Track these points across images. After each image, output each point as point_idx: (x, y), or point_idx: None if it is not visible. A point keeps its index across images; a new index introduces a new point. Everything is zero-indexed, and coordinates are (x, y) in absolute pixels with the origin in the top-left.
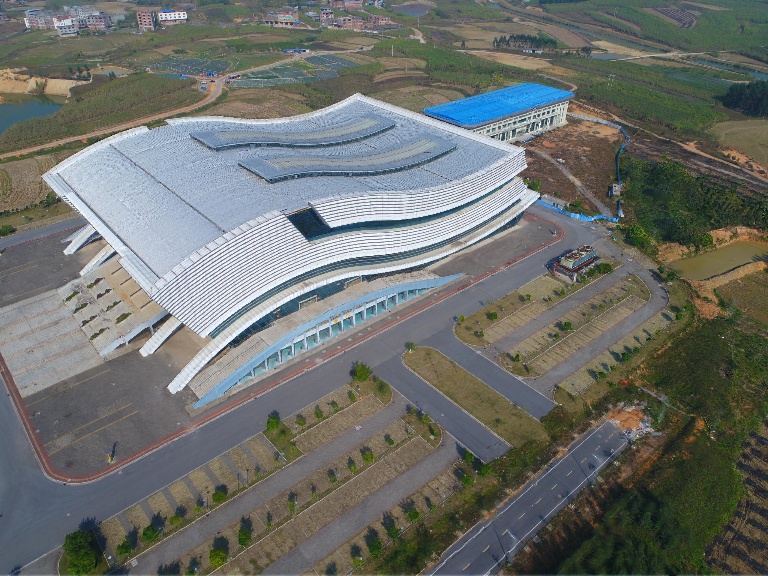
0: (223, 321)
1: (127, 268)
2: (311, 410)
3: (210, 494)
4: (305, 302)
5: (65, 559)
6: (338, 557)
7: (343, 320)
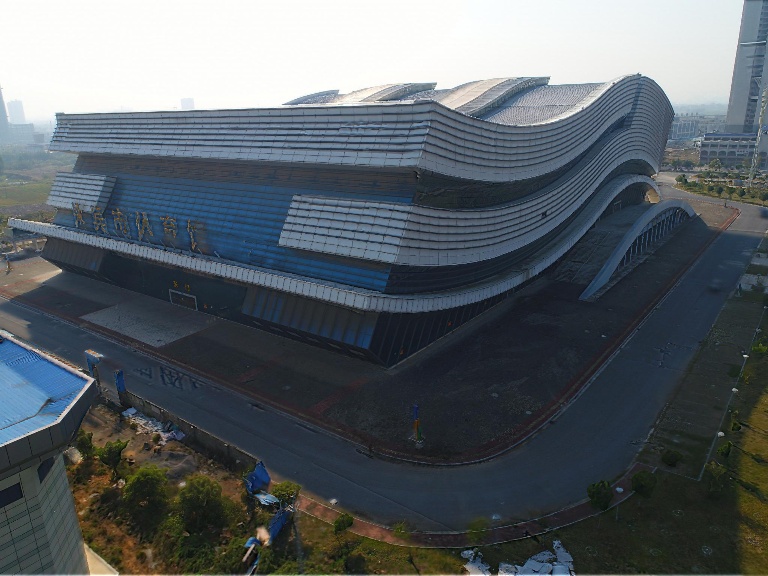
0: None
1: None
2: None
3: None
4: None
5: None
6: None
7: None
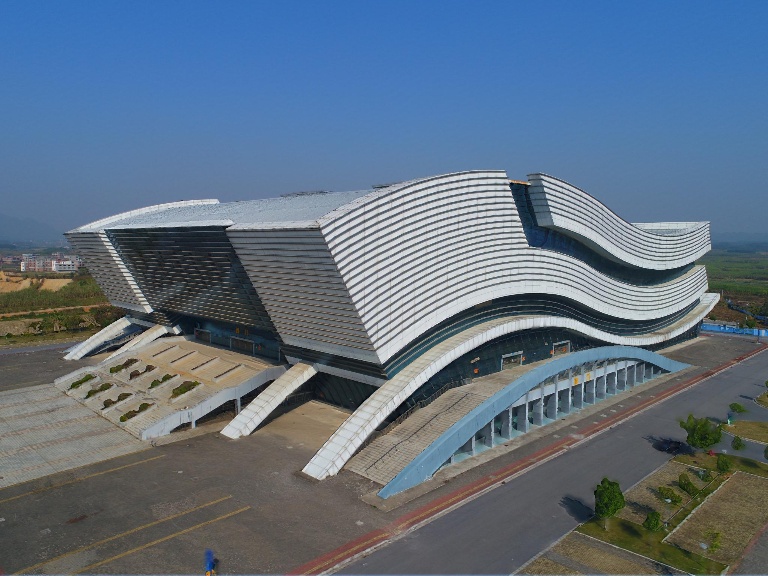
0: (407, 345)
1: (249, 226)
2: (645, 494)
3: None
4: (507, 360)
5: None
6: None
7: (583, 383)
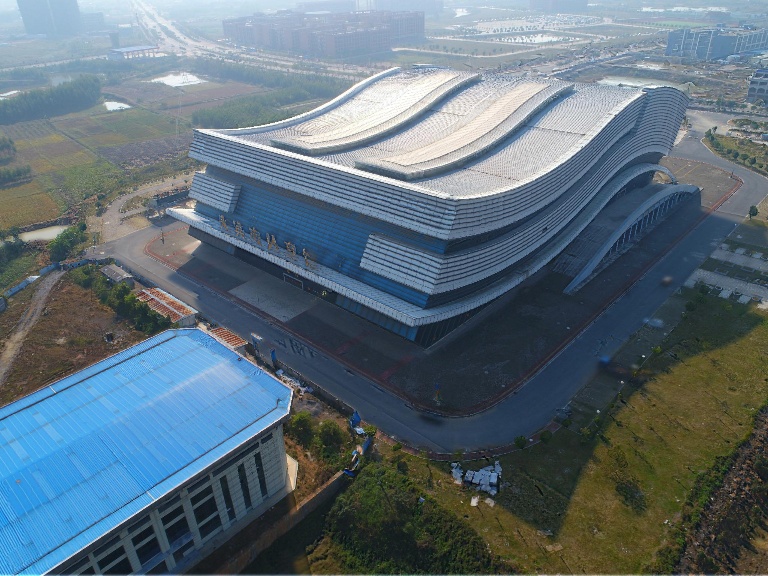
0: None
1: None
2: None
3: None
4: None
5: None
6: None
7: None
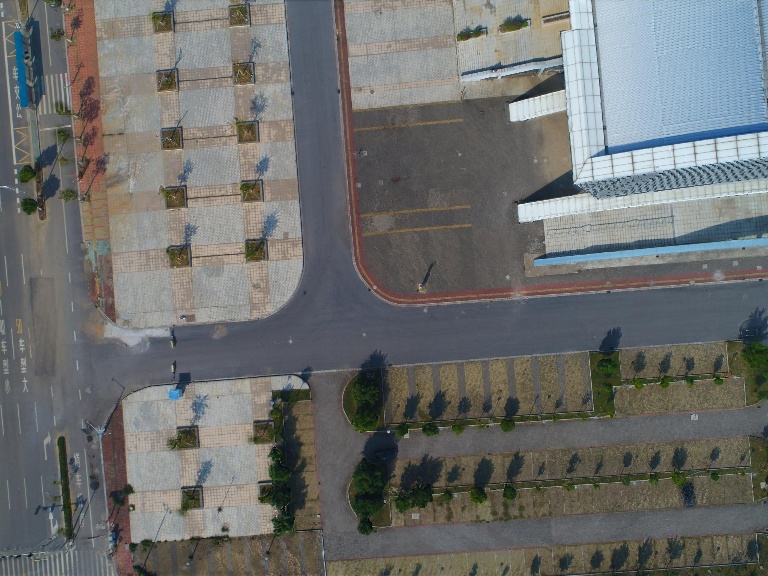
0: None
1: (568, 69)
2: (660, 356)
3: (500, 402)
4: None
5: (351, 390)
6: (579, 553)
7: None
